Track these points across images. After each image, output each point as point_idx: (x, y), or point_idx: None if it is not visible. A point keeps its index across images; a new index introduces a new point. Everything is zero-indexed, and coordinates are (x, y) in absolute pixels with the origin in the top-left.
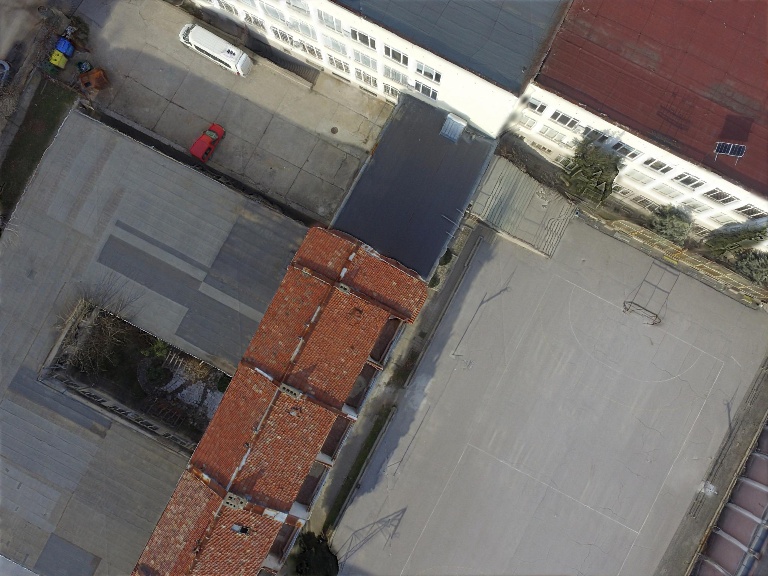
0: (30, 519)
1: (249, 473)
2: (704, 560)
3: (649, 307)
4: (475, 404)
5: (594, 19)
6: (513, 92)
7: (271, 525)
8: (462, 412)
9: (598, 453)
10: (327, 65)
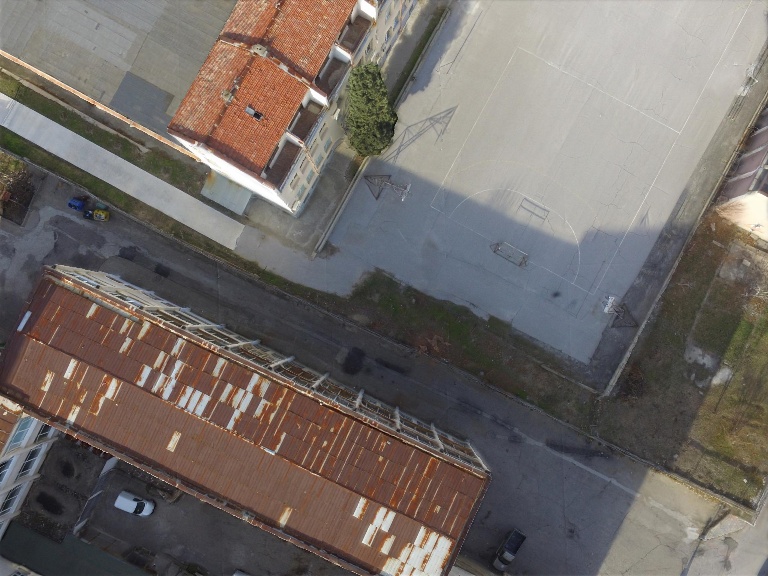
0: (107, 58)
1: None
2: (742, 159)
3: None
4: (525, 10)
5: None
6: None
7: None
8: (513, 17)
9: (642, 58)
10: None
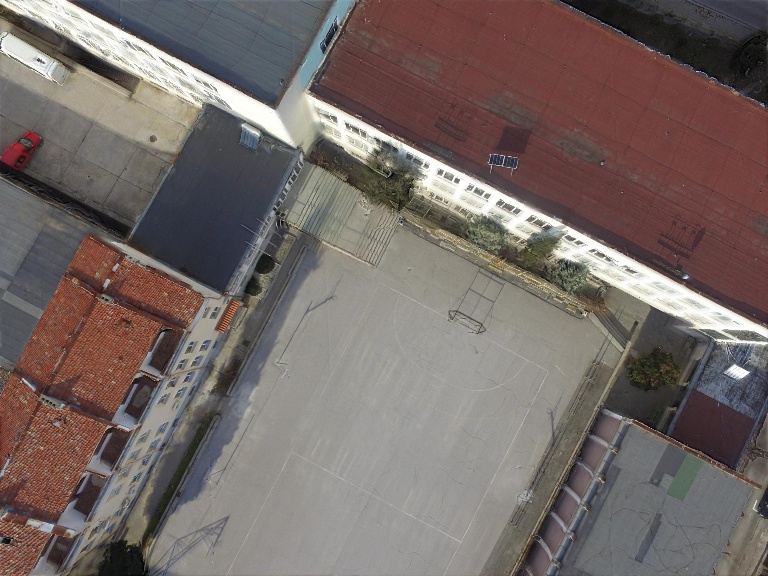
0: None
1: (9, 484)
2: (525, 569)
3: (474, 316)
4: (299, 412)
5: (375, 30)
6: (269, 104)
7: (37, 535)
8: (286, 420)
9: (421, 462)
10: (141, 74)
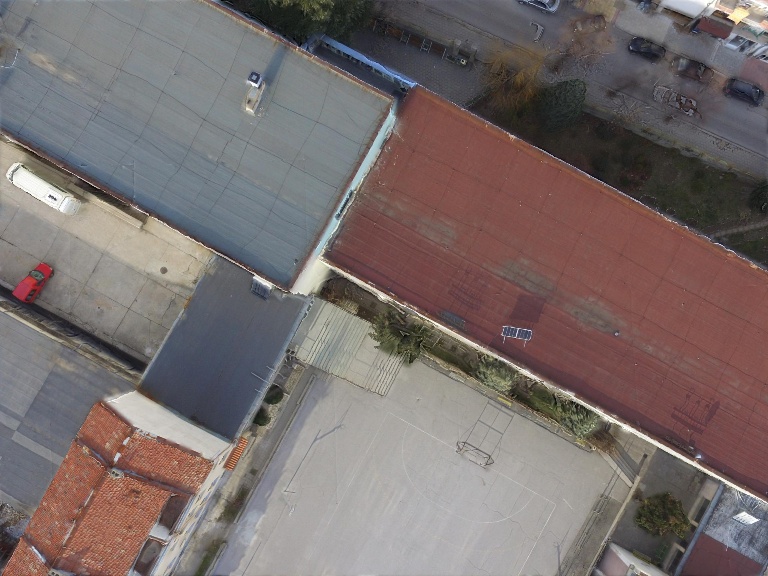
0: None
1: None
2: None
3: (483, 447)
4: (306, 541)
5: (390, 194)
6: (282, 286)
7: None
8: (292, 549)
9: None
10: None
